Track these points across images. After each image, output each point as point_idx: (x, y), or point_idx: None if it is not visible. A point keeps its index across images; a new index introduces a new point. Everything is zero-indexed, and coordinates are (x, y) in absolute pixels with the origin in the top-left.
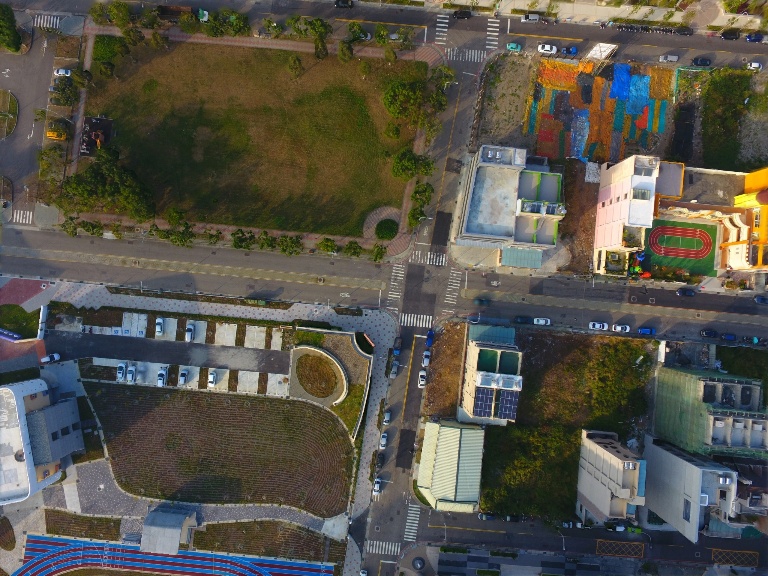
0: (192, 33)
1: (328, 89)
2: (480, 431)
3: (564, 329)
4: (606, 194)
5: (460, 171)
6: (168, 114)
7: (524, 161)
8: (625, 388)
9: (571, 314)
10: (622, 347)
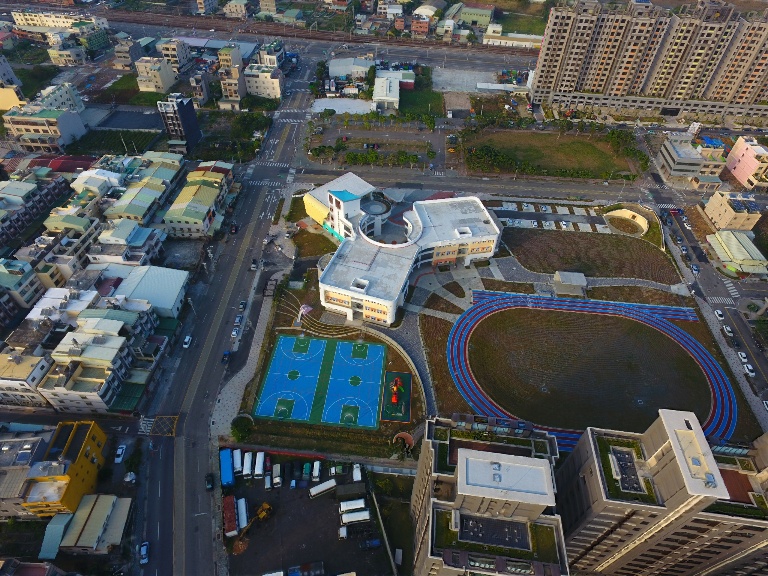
0: (504, 129)
1: (573, 142)
2: (742, 233)
3: None
4: (733, 163)
5: (653, 162)
6: None
7: None
8: None
9: None
10: None
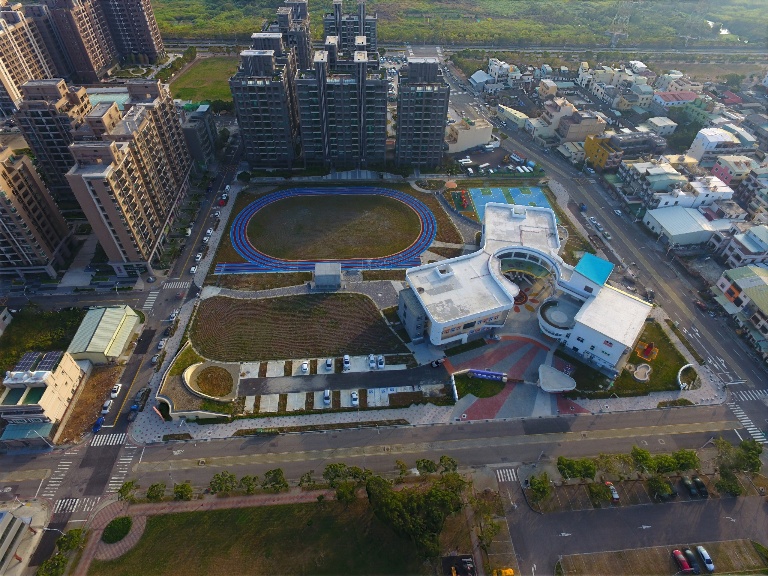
0: None
1: None
2: (69, 353)
3: None
4: None
5: None
6: None
7: None
8: None
9: None
10: None
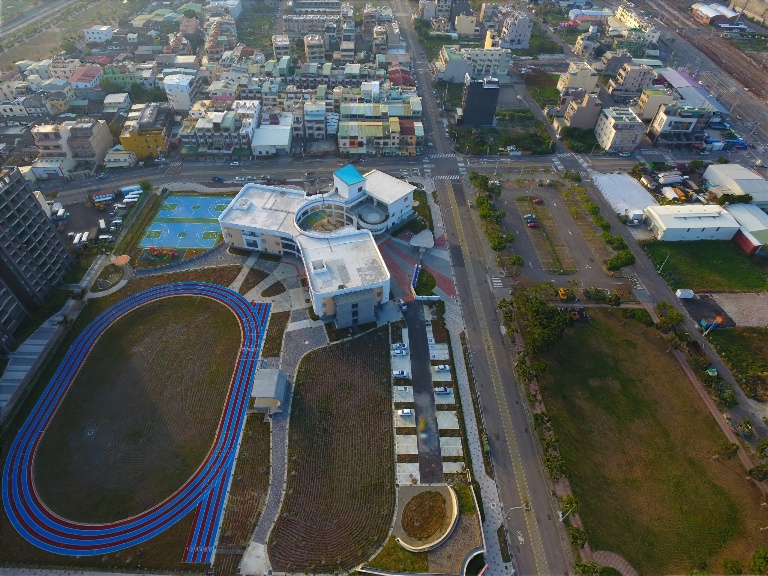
0: (690, 368)
1: (723, 491)
2: None
3: None
4: None
5: None
6: (616, 358)
7: None
8: None
9: None
10: None
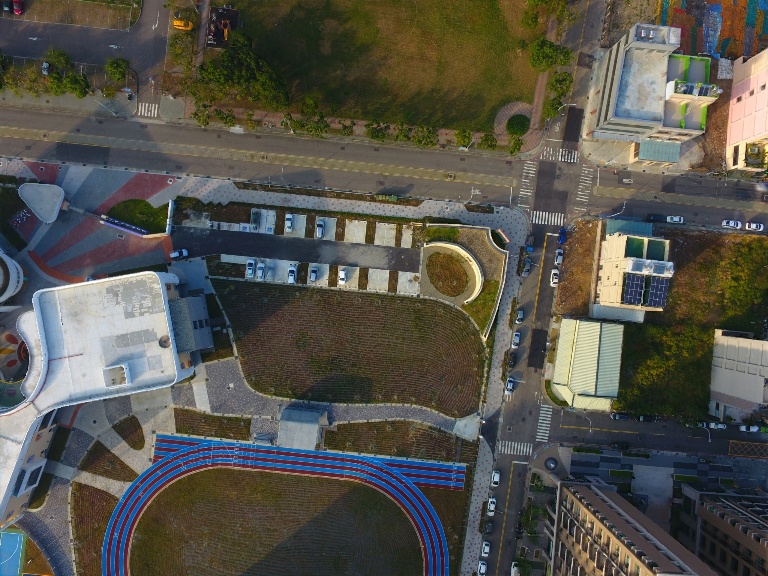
0: None
1: None
2: (619, 326)
3: (697, 228)
4: (744, 87)
5: (592, 66)
6: (295, 5)
7: (679, 40)
8: (758, 288)
9: (704, 212)
10: (757, 245)
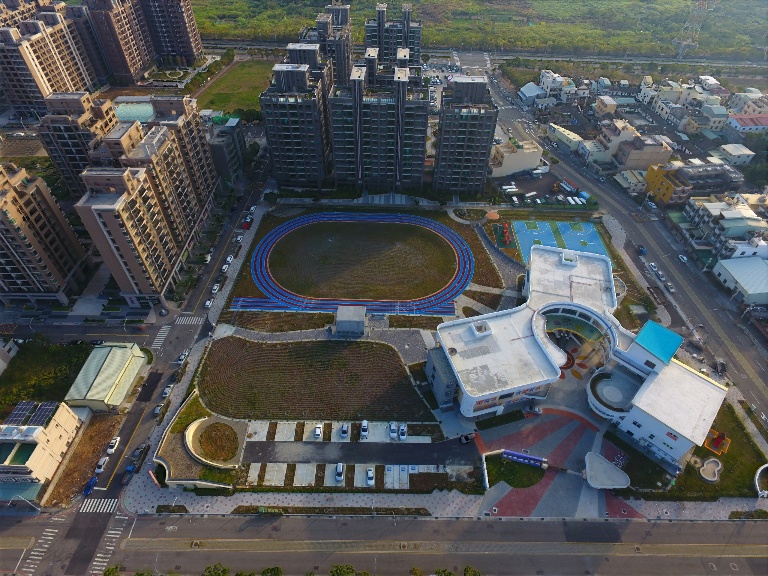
0: None
1: None
2: (68, 399)
3: None
4: None
5: None
6: None
7: None
8: None
9: None
10: None
